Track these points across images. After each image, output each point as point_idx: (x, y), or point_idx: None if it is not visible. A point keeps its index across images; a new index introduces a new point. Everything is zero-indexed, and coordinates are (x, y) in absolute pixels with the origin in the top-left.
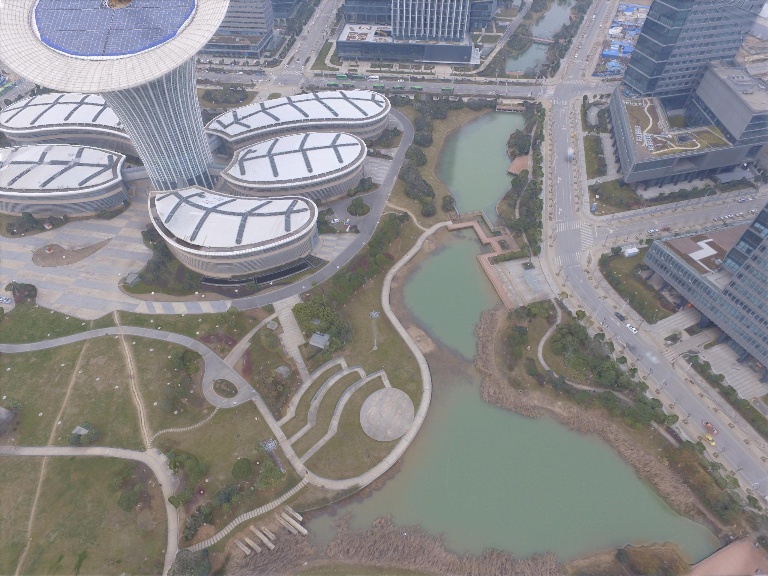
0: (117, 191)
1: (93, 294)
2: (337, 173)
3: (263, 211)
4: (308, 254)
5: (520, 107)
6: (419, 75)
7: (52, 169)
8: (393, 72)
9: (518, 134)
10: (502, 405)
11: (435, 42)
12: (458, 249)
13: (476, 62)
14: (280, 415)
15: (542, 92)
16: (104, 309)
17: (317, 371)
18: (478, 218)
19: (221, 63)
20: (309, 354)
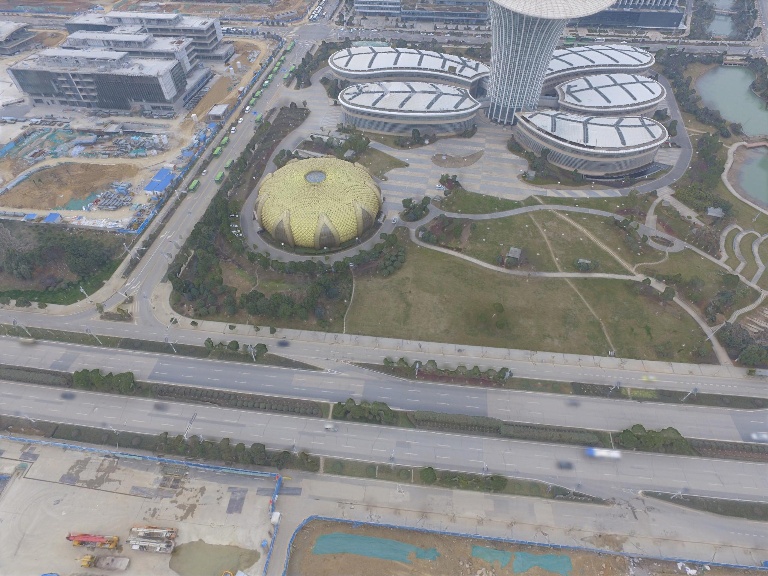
0: (474, 115)
1: (505, 185)
2: (655, 101)
3: (626, 124)
4: (652, 161)
5: (744, 62)
6: (636, 38)
7: (427, 96)
8: (611, 36)
9: (763, 80)
10: None
11: (647, 10)
12: (763, 161)
13: (683, 27)
14: (719, 256)
15: (759, 50)
16: (523, 194)
17: (723, 232)
18: (764, 140)
19: (456, 28)
20: (709, 222)
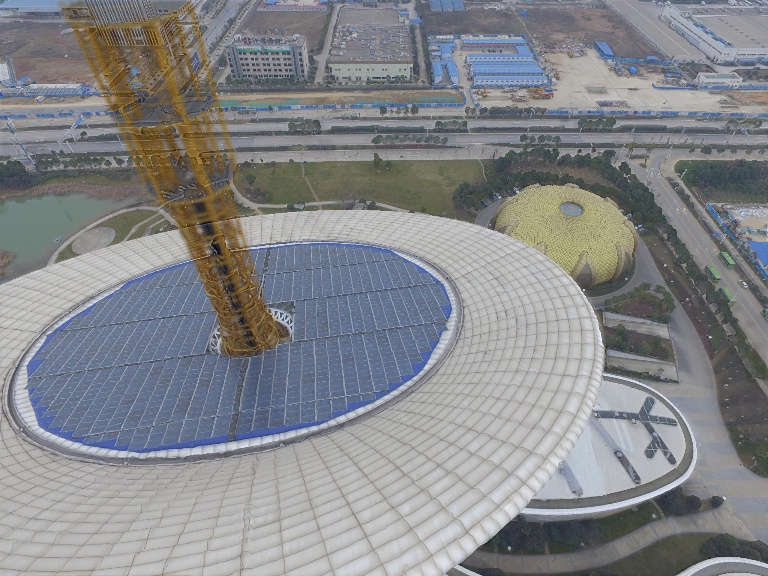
0: None
1: None
2: None
3: None
4: None
5: None
6: None
7: None
8: None
9: None
10: (4, 251)
11: None
12: None
13: None
14: None
15: None
16: None
17: None
18: None
19: None
20: None
